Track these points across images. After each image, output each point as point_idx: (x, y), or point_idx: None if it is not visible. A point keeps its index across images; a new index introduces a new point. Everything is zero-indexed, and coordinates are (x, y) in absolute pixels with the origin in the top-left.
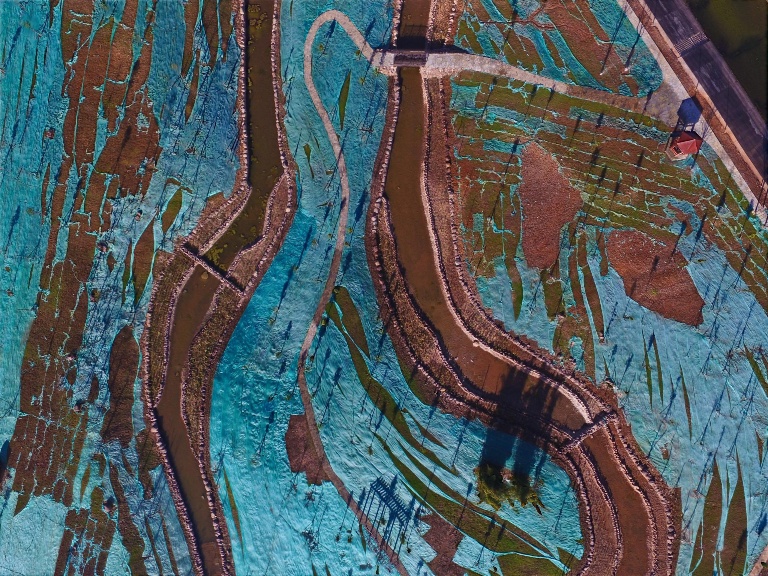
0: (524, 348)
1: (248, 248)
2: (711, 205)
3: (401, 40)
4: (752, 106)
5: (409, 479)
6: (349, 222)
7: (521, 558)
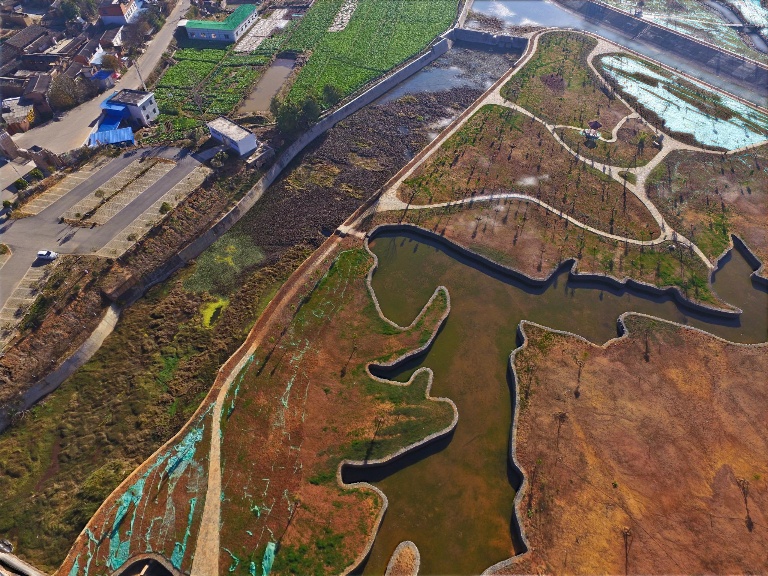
0: None
1: None
2: (620, 4)
3: None
4: None
5: None
6: None
7: None
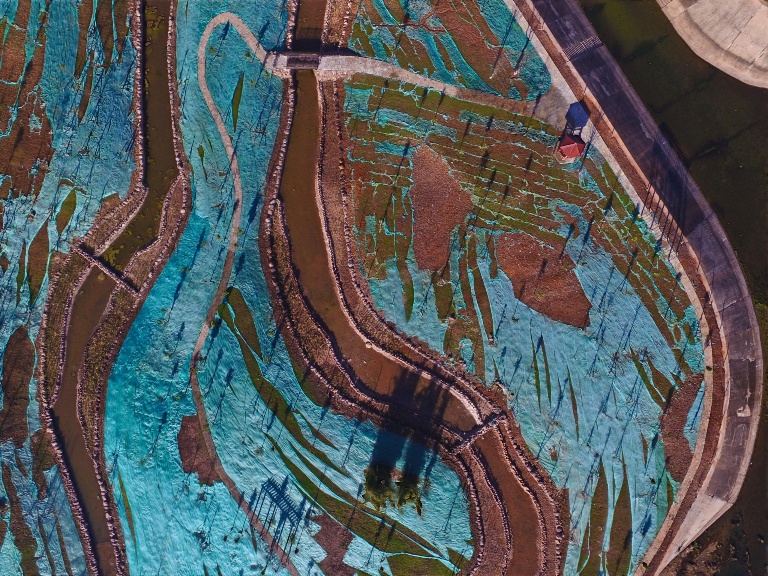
0: (415, 350)
1: (143, 249)
2: (598, 208)
3: (297, 42)
4: (645, 110)
5: (300, 480)
6: (242, 224)
7: (411, 558)
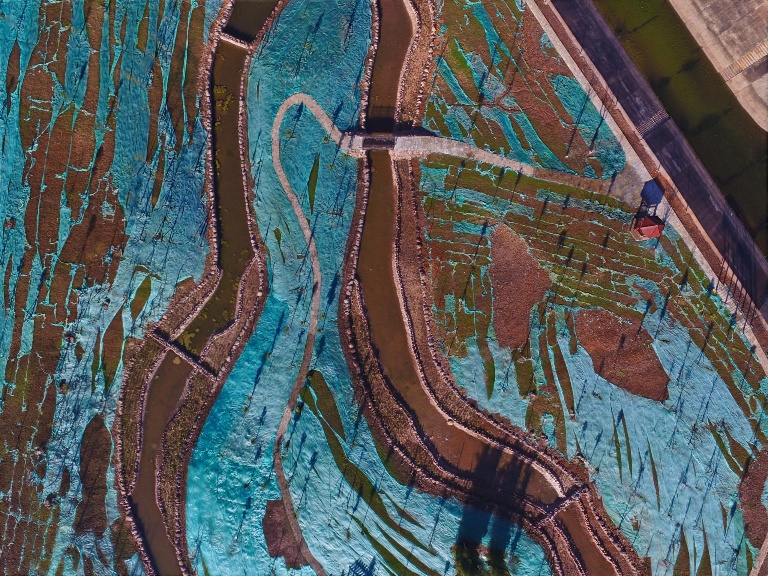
0: (497, 426)
1: (220, 333)
2: (674, 284)
3: (370, 121)
4: (712, 182)
5: (387, 560)
6: (322, 306)
7: None
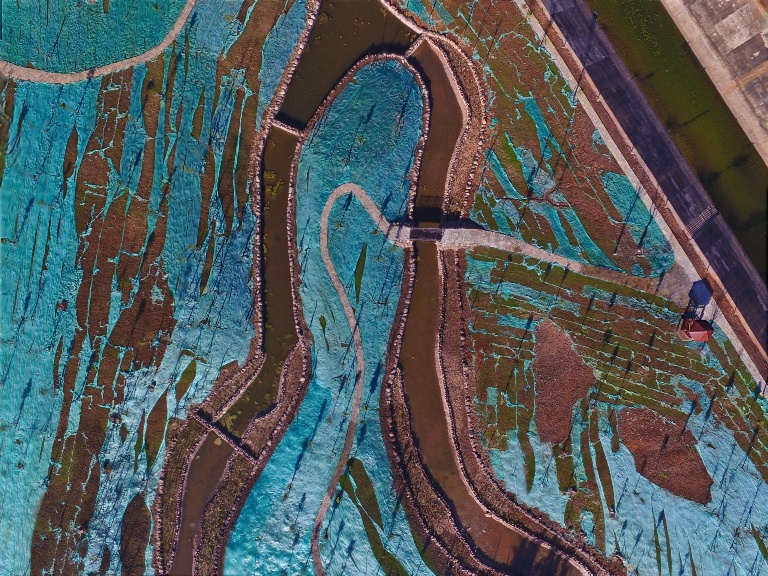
0: (536, 521)
1: (262, 416)
2: (720, 385)
3: (417, 210)
4: (760, 279)
5: None
6: (364, 394)
7: None
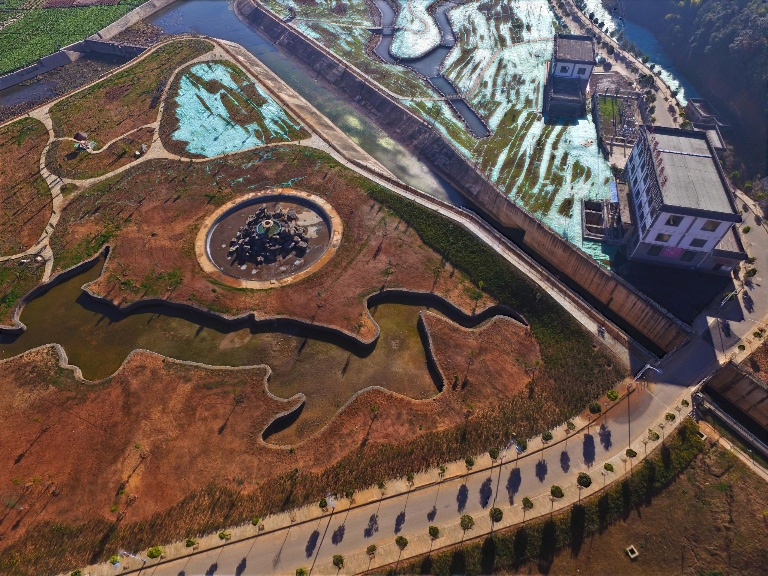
0: None
1: (443, 5)
2: None
3: None
4: (260, 34)
5: None
6: None
7: None
